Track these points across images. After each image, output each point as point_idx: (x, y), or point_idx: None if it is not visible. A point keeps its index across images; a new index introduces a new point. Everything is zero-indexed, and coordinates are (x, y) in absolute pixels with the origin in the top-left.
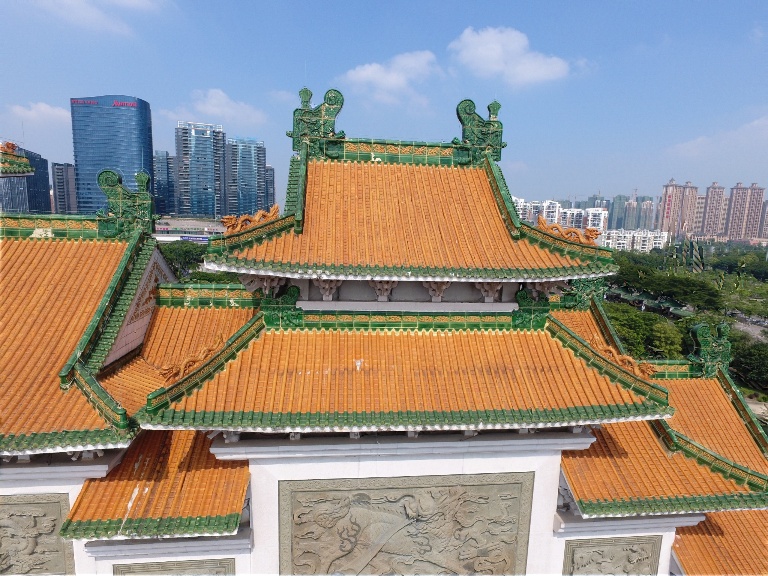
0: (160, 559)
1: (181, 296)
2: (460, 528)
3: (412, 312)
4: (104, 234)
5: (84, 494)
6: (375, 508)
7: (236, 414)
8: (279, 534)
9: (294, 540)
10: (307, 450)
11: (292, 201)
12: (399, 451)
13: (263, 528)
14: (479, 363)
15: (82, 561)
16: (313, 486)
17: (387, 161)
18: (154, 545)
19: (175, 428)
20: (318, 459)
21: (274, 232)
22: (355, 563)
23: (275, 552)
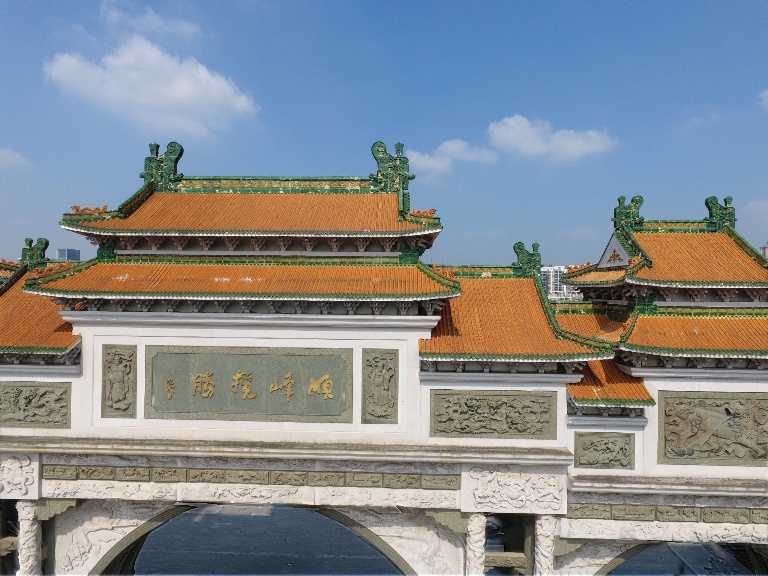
0: (597, 430)
1: (554, 308)
2: (757, 424)
3: (714, 307)
4: (517, 274)
5: (571, 389)
6: (709, 409)
7: (654, 347)
8: (658, 421)
9: (665, 425)
10: (678, 372)
11: (632, 253)
12: (725, 375)
13: (650, 416)
14: (760, 332)
15: (561, 428)
16: (675, 395)
17: (668, 231)
18: (602, 418)
19: (632, 351)
20: (679, 380)
21: (641, 267)
22: (699, 441)
23: (656, 431)
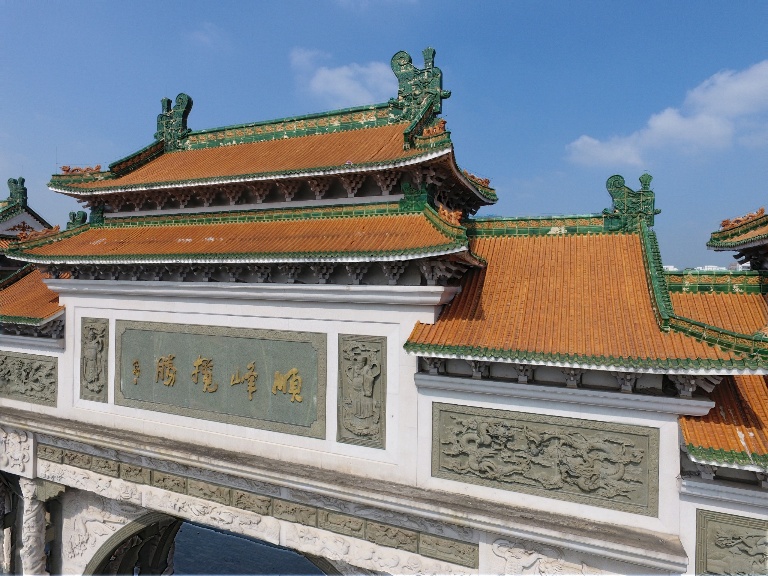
0: (749, 514)
1: (679, 282)
2: None
3: None
4: (609, 228)
5: None
6: None
7: None
8: None
9: None
10: None
11: None
12: None
13: None
14: None
15: (666, 497)
16: None
17: None
18: (758, 493)
19: None
20: None
21: None
22: None
23: None
